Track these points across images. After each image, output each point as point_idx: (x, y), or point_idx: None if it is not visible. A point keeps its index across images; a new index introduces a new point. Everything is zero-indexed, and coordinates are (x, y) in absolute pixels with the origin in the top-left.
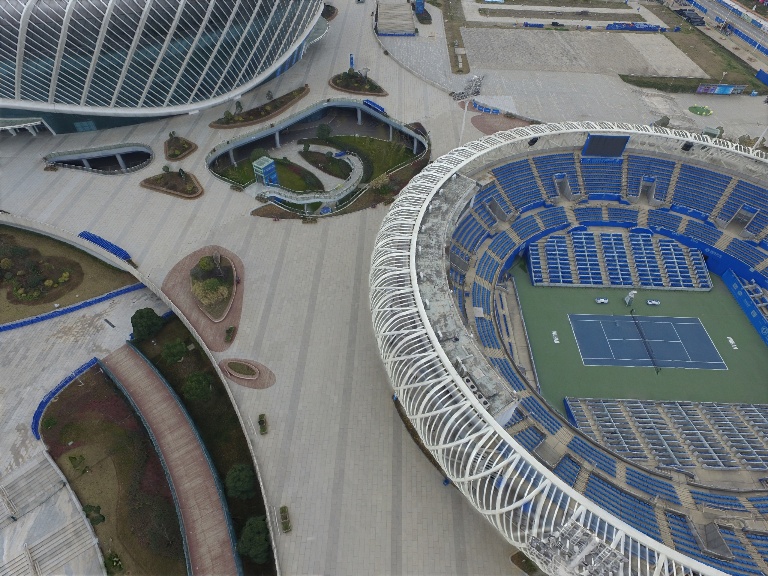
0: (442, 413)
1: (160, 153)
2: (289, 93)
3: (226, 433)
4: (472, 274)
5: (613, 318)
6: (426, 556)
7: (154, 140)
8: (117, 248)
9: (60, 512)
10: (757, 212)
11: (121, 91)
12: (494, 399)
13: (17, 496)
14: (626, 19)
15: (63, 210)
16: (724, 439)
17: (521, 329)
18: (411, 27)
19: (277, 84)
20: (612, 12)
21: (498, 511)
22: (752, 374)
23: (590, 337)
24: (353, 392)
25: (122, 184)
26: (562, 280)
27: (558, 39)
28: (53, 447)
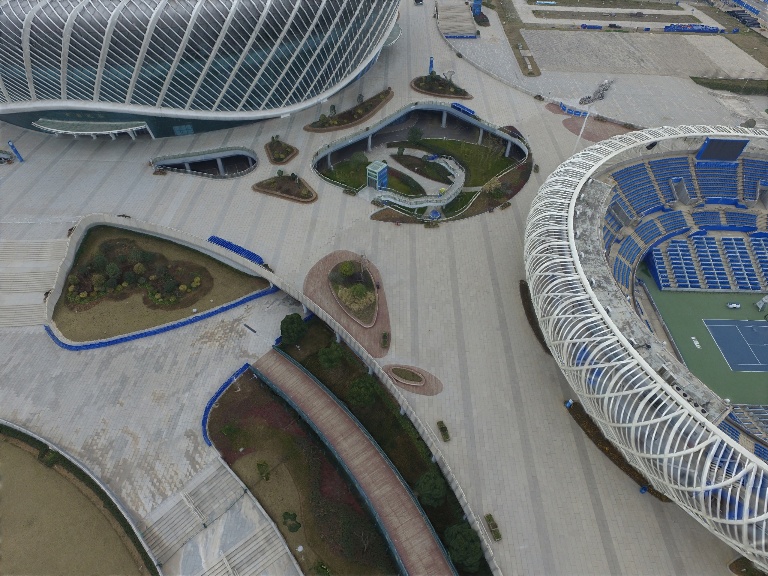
0: (662, 422)
1: (263, 157)
2: (375, 96)
3: (391, 439)
4: None
5: (749, 323)
6: (643, 565)
7: (253, 144)
8: (250, 253)
9: (247, 519)
10: None
11: (225, 95)
12: (707, 407)
13: (202, 503)
14: (681, 21)
15: (183, 214)
16: None
17: (664, 334)
18: (472, 29)
19: (360, 87)
20: (665, 13)
21: (747, 521)
22: None
23: (731, 342)
24: (523, 399)
25: (234, 188)
26: (690, 285)
27: (620, 41)
28: (226, 453)
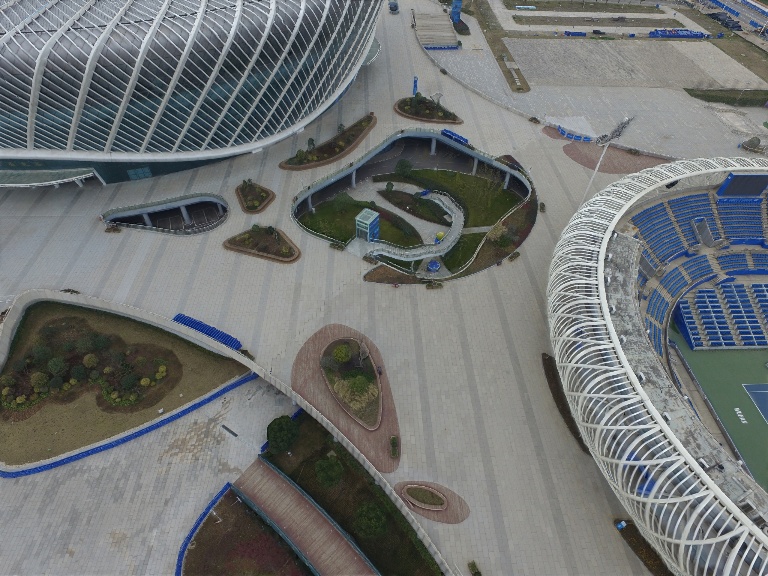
0: None
1: (234, 204)
2: (357, 124)
3: (409, 575)
4: None
5: None
6: None
7: (222, 187)
8: (225, 335)
9: None
10: None
11: (187, 134)
12: None
13: None
14: (665, 25)
15: (142, 284)
16: None
17: (707, 411)
18: (453, 39)
19: (338, 112)
20: (648, 17)
21: None
22: None
23: None
24: (566, 520)
25: (202, 246)
26: (723, 342)
27: (607, 49)
28: None
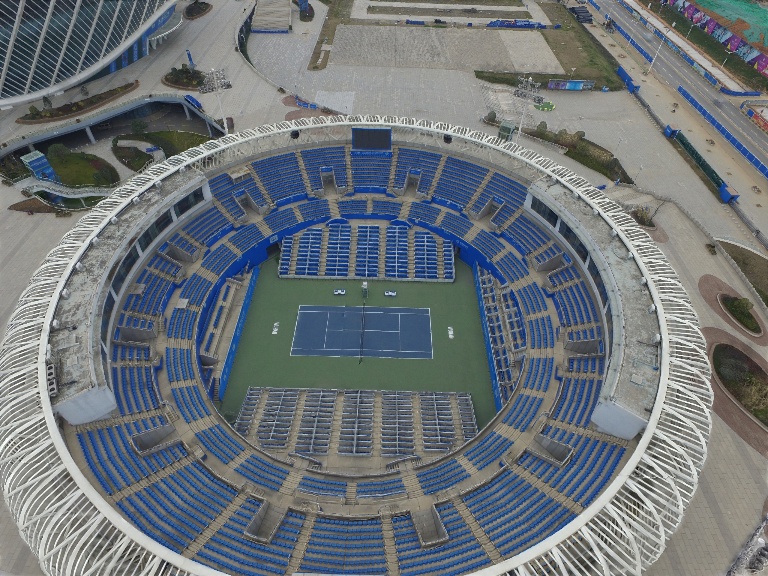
0: (5, 400)
1: None
2: (114, 89)
3: None
4: (197, 266)
5: (343, 309)
6: None
7: None
8: None
9: None
10: (503, 204)
11: None
12: (70, 386)
13: None
14: (513, 16)
15: None
16: None
17: (236, 320)
18: (286, 24)
19: (109, 80)
20: (502, 10)
21: (5, 496)
22: (455, 363)
23: (310, 328)
24: None
25: None
26: (307, 272)
27: (431, 36)
28: None
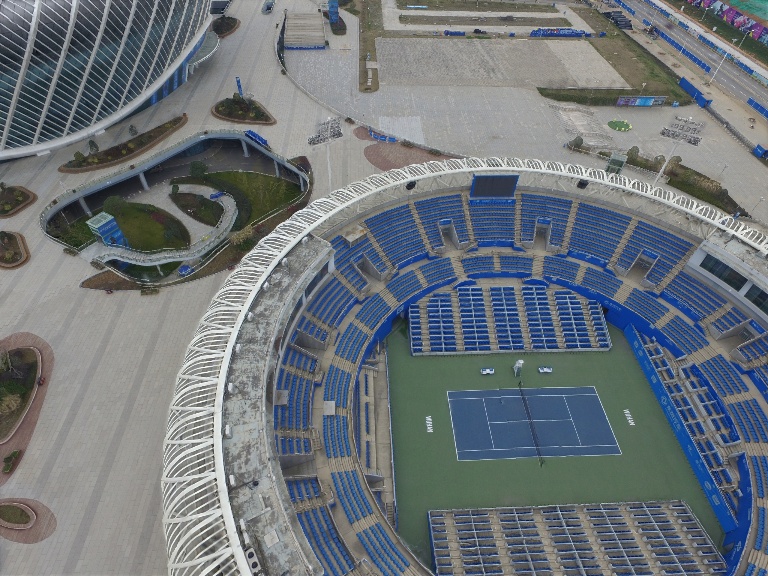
0: None
1: None
2: (162, 125)
3: None
4: (330, 355)
5: (498, 393)
6: None
7: None
8: None
9: None
10: (657, 258)
11: None
12: None
13: None
14: (552, 24)
15: None
16: (606, 559)
17: (386, 420)
18: (321, 39)
19: (151, 114)
20: (538, 16)
21: None
22: (648, 458)
23: (469, 421)
24: (152, 538)
25: None
26: (444, 348)
27: (478, 49)
28: None
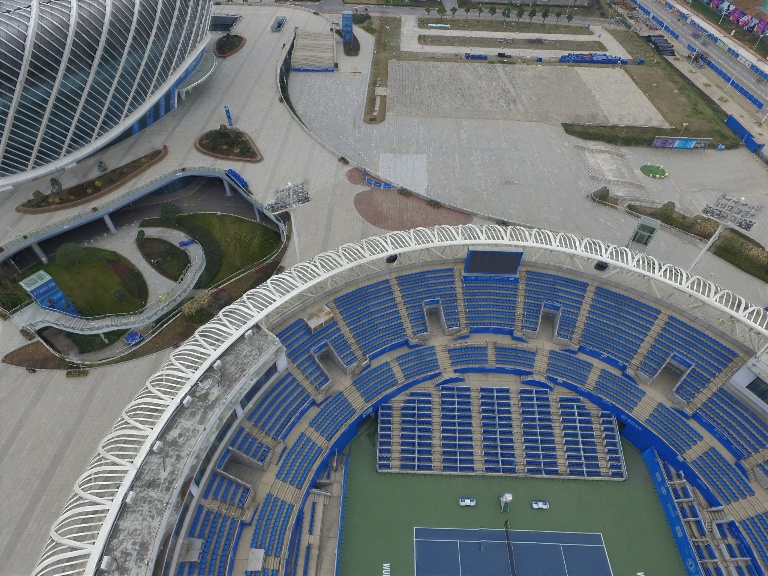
0: None
1: None
2: (137, 159)
3: None
4: (270, 478)
5: (478, 535)
6: None
7: None
8: None
9: None
10: (691, 368)
11: None
12: None
13: None
14: (584, 48)
15: None
16: None
17: (331, 570)
18: (331, 61)
19: (131, 145)
20: (570, 39)
21: None
22: None
23: (437, 575)
24: None
25: None
26: (417, 465)
27: (499, 75)
28: None
